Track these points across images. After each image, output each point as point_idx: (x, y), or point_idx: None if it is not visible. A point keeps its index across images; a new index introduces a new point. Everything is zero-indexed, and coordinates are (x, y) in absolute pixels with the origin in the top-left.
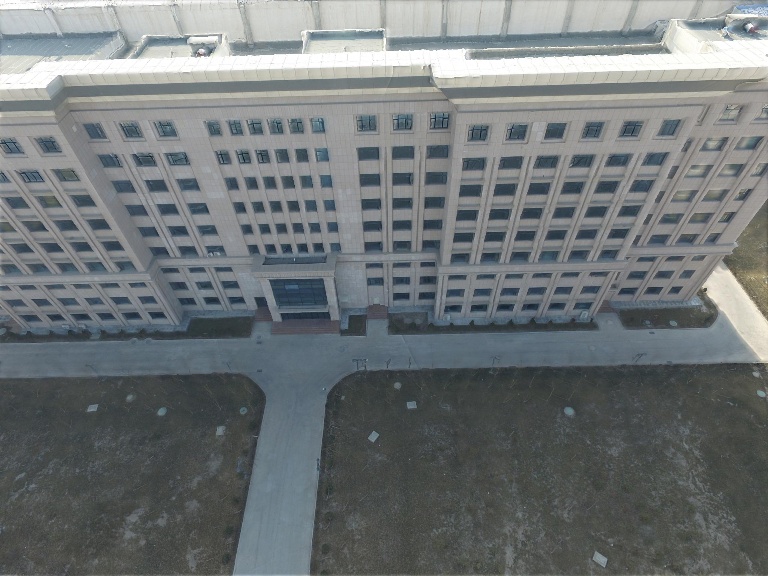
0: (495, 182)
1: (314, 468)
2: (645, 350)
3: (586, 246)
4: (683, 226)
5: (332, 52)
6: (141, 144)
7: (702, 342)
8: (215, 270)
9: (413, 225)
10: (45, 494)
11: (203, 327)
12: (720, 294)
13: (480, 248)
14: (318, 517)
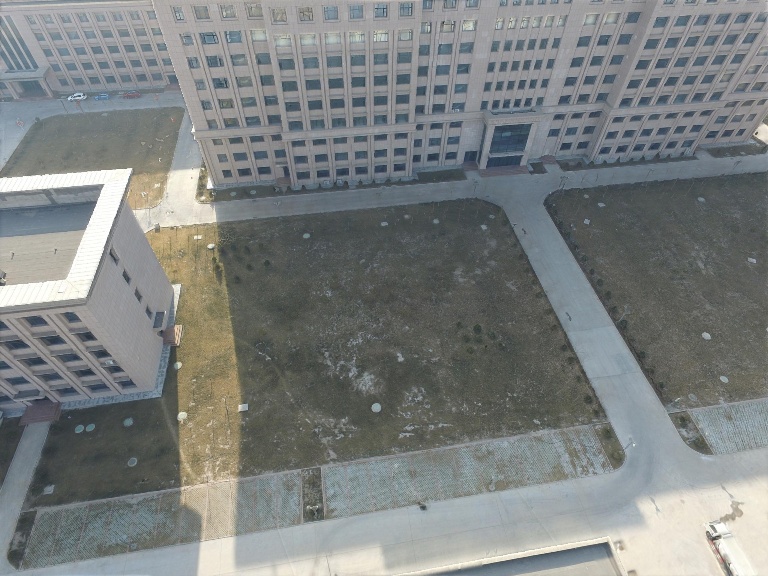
0: (669, 36)
1: (559, 239)
2: (732, 167)
3: (705, 89)
4: (759, 75)
5: None
6: (453, 13)
7: (764, 161)
8: (449, 126)
9: (598, 79)
10: (388, 267)
11: (429, 177)
12: (765, 137)
13: (642, 92)
14: (578, 259)
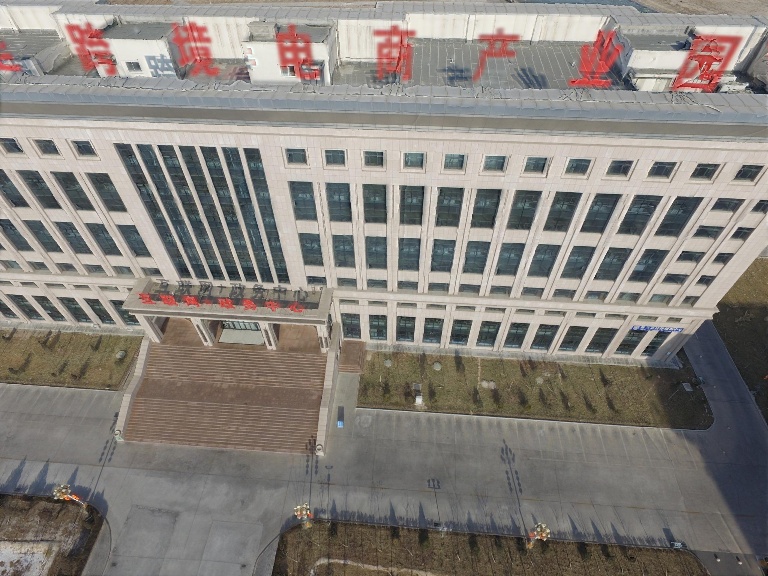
0: None
1: None
2: None
3: None
4: None
5: (152, 31)
6: None
7: None
8: None
9: None
10: None
11: None
12: None
13: None
14: None
